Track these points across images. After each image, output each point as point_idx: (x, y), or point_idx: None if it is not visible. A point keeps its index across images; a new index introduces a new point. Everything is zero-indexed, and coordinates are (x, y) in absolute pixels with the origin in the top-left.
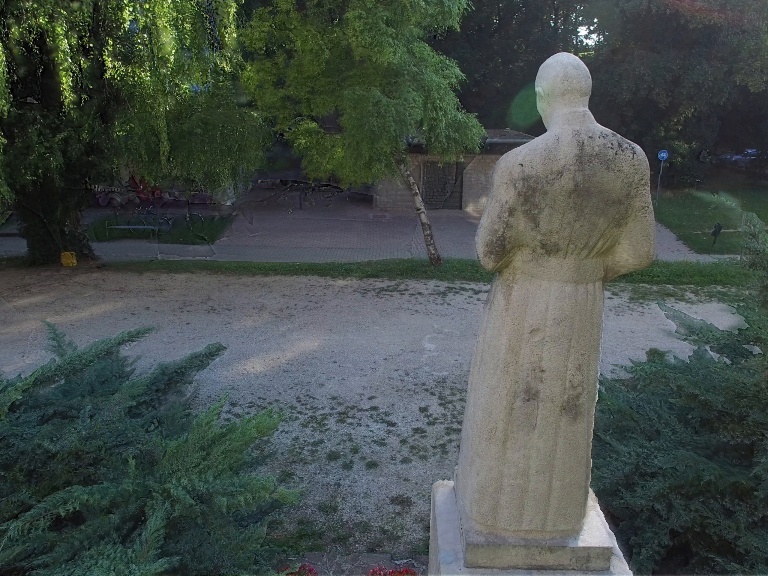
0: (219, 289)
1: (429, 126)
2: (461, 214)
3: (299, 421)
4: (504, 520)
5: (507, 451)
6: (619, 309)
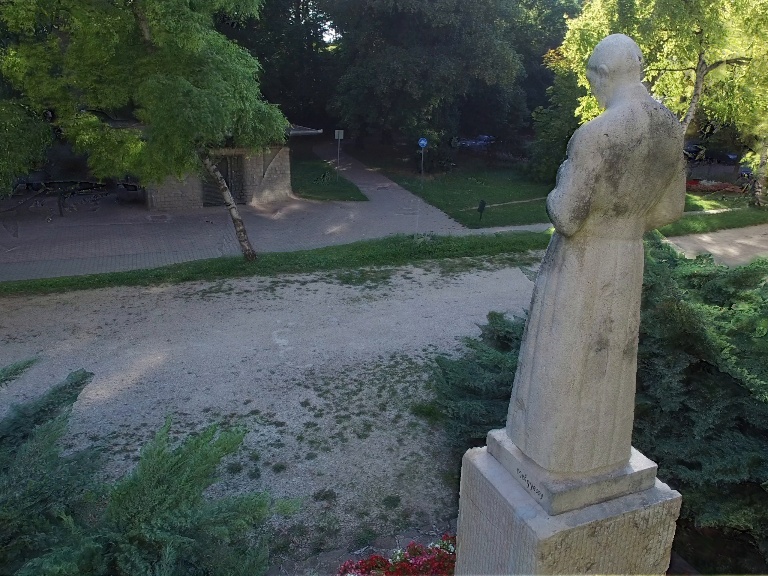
0: (8, 314)
1: (237, 117)
2: (246, 209)
3: (180, 441)
4: (579, 464)
5: (582, 400)
6: (437, 283)
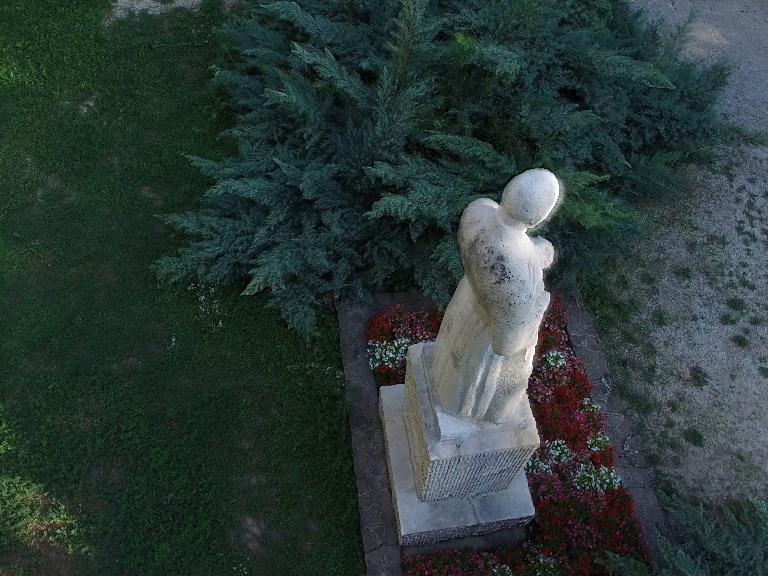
0: None
1: None
2: None
3: None
4: None
5: None
6: None
